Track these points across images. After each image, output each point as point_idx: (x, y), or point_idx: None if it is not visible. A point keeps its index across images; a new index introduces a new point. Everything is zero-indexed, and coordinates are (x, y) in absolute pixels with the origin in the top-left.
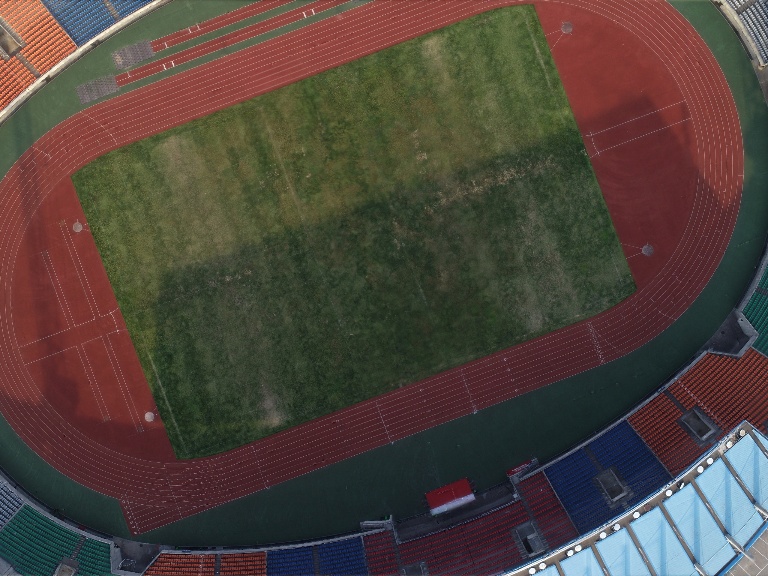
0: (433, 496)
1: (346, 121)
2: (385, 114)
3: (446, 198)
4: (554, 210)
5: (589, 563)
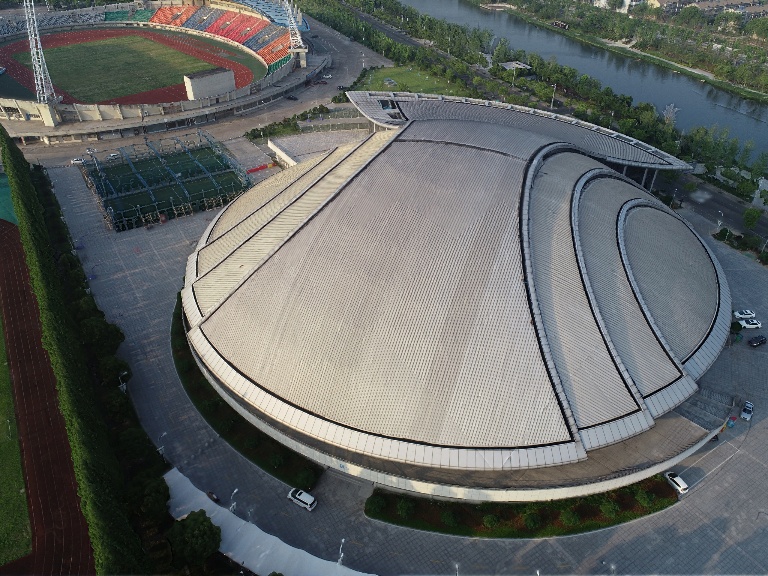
0: None
1: None
2: (171, 61)
3: None
4: (132, 86)
5: None
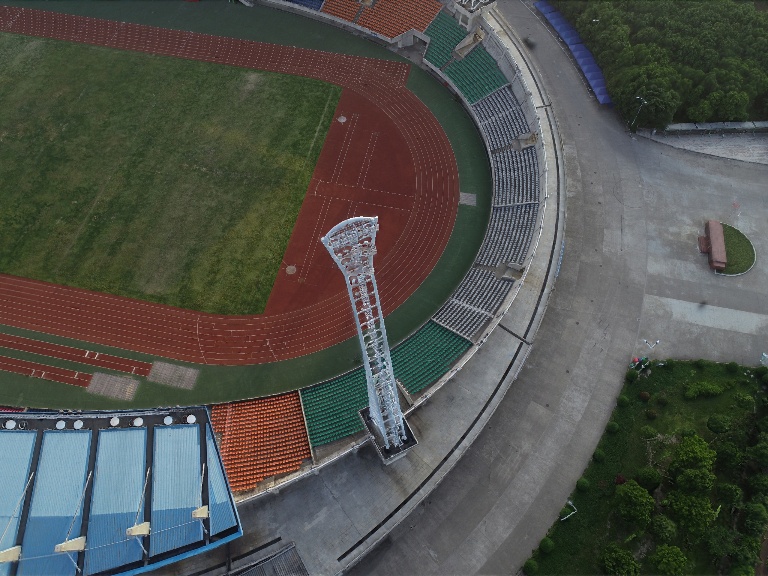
0: None
1: (5, 223)
2: None
3: (1, 135)
4: None
5: None
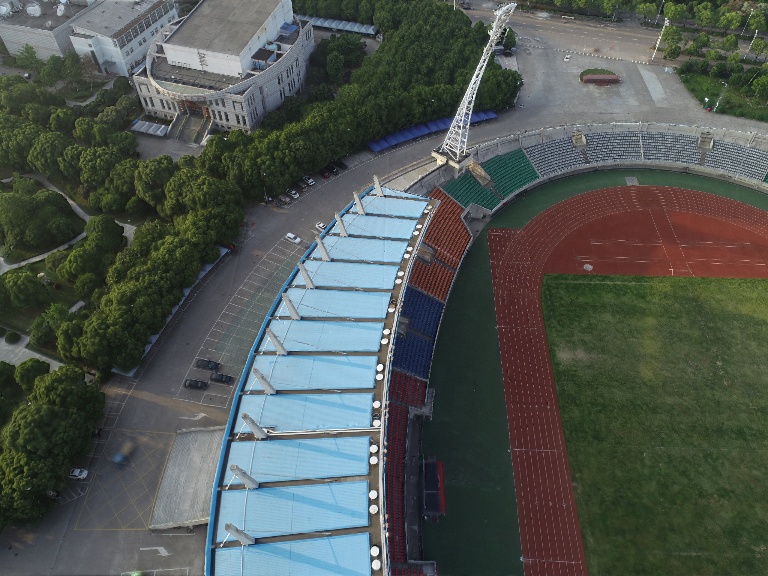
0: (438, 468)
1: None
2: None
3: None
4: None
5: (349, 573)
